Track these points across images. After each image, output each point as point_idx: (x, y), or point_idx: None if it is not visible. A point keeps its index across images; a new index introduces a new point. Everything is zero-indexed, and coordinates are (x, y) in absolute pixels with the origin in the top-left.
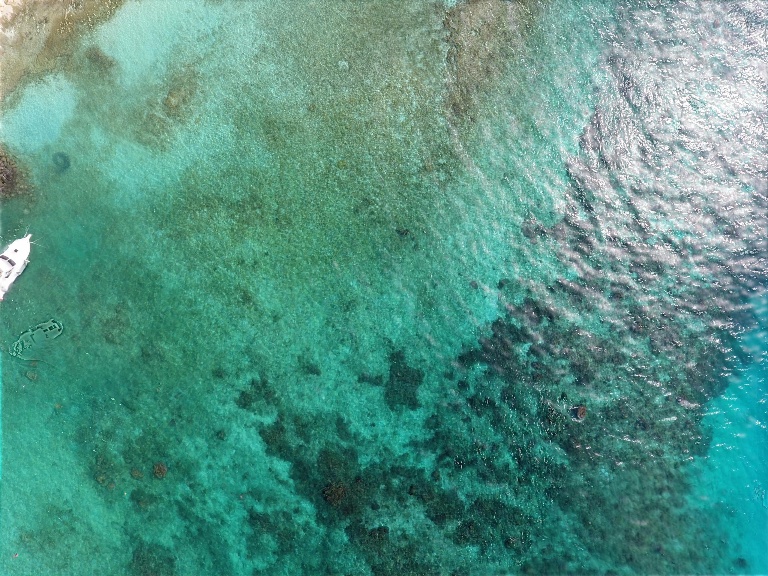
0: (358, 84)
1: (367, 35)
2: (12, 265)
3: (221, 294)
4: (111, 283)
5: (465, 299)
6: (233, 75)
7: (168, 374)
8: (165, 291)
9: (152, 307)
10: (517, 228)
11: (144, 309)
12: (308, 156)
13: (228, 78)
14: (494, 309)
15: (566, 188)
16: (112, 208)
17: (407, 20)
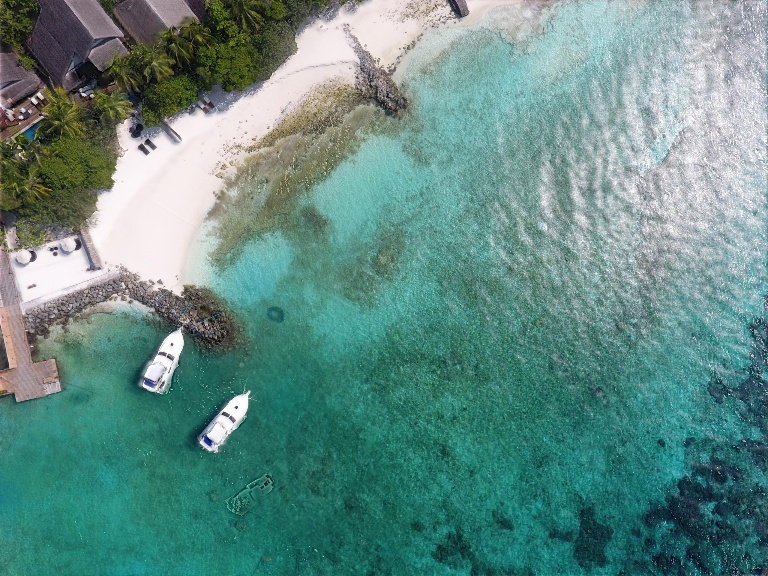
0: (556, 245)
1: (565, 197)
2: (233, 422)
3: (421, 448)
4: (317, 435)
5: (653, 457)
6: (438, 234)
7: (368, 526)
8: (368, 444)
9: (355, 460)
10: (704, 387)
11: (348, 462)
12: (507, 314)
13: (433, 237)
14: (681, 467)
15: (751, 348)
16: (321, 362)
17: (603, 183)
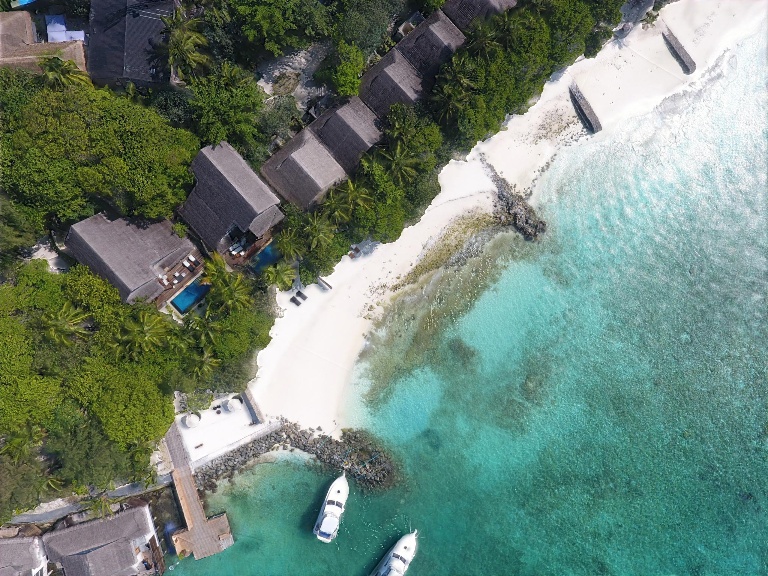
0: (700, 356)
1: (706, 307)
2: (404, 562)
3: (580, 567)
4: (480, 563)
5: None
6: (584, 355)
7: None
8: (529, 567)
9: None
10: None
11: None
12: (656, 429)
13: (579, 359)
14: None
15: None
16: (478, 492)
17: (743, 289)
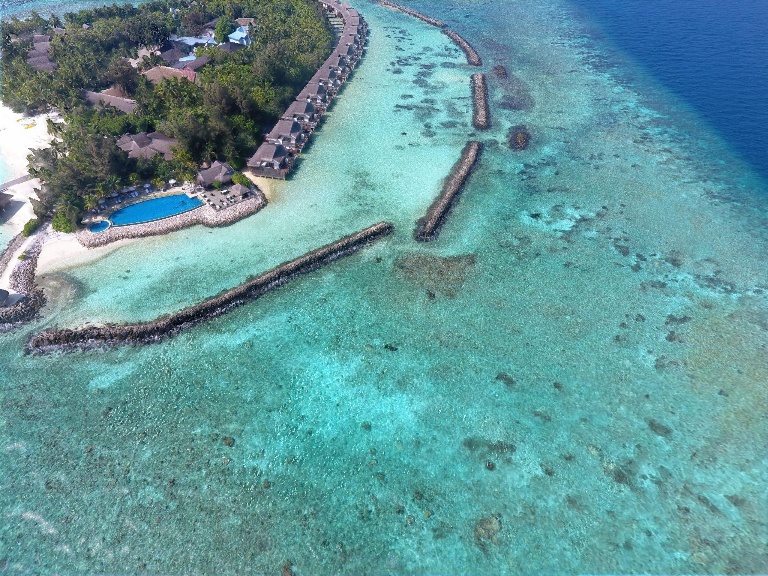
0: (85, 8)
1: None
2: None
3: None
4: None
5: None
6: None
7: None
8: None
9: None
10: None
11: None
12: None
13: None
14: None
15: None
16: None
17: None
